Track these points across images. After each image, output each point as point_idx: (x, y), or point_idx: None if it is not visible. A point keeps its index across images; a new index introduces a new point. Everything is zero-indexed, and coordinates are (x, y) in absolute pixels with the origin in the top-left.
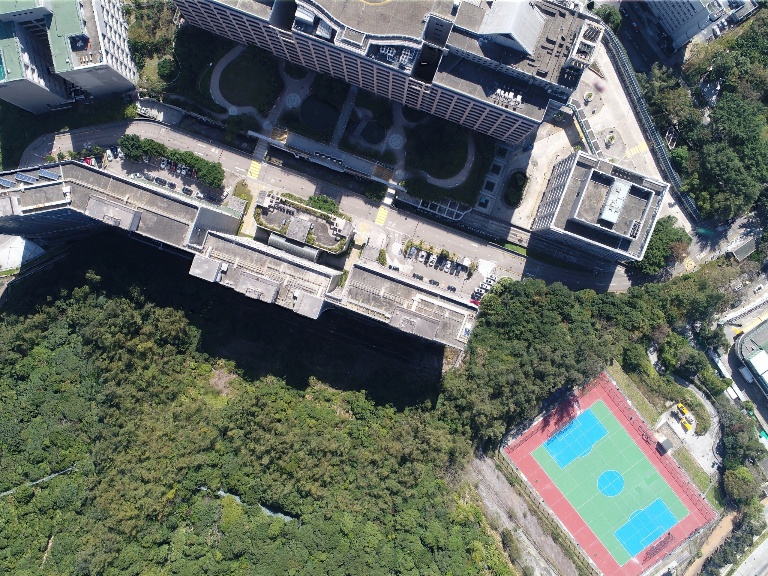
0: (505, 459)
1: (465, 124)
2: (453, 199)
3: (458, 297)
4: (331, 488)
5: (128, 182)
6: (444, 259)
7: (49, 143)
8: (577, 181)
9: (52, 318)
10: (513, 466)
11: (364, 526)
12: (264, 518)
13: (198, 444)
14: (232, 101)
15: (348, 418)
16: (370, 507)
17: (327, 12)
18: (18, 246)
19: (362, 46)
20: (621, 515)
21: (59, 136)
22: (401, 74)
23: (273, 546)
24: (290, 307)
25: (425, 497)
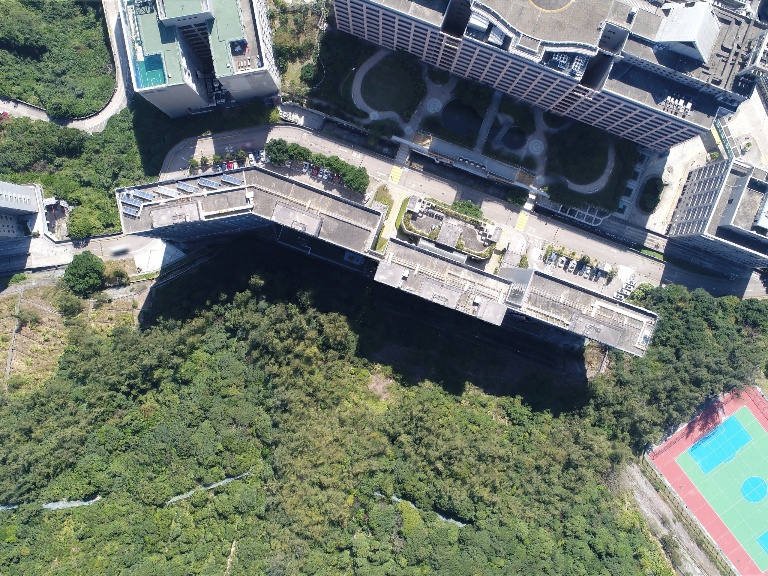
0: (649, 465)
1: (611, 130)
2: (594, 205)
3: None
4: (499, 494)
5: (310, 188)
6: (584, 265)
7: (191, 147)
8: (728, 188)
9: (209, 322)
10: (657, 472)
11: (538, 532)
12: (442, 524)
13: (371, 449)
14: (373, 106)
15: (505, 424)
16: (541, 513)
17: (503, 19)
18: (159, 250)
19: (537, 53)
20: (764, 521)
21: (201, 140)
22: (570, 81)
23: (453, 552)
24: (470, 313)
25: (589, 503)
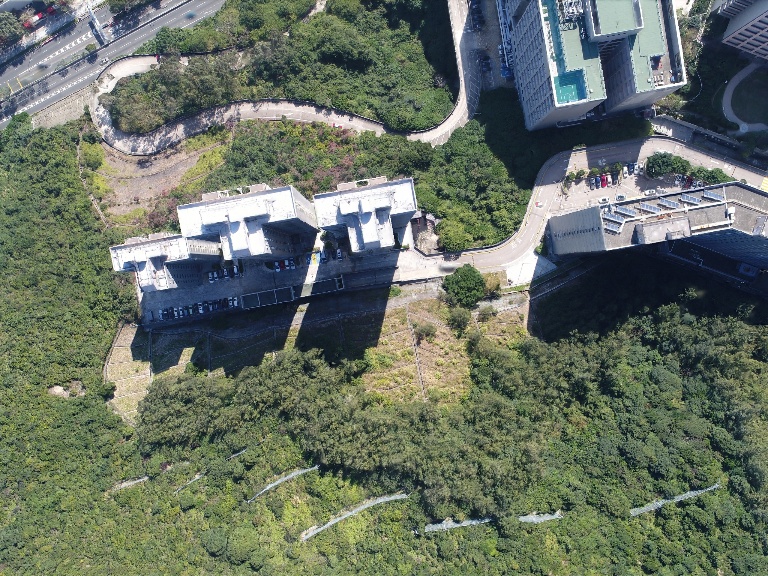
0: None
1: None
2: None
3: None
4: None
5: None
6: None
7: (565, 160)
8: None
9: None
10: None
11: None
12: None
13: None
14: (743, 118)
15: None
16: None
17: None
18: (531, 262)
19: None
20: None
21: (575, 153)
22: None
23: None
24: None
25: None
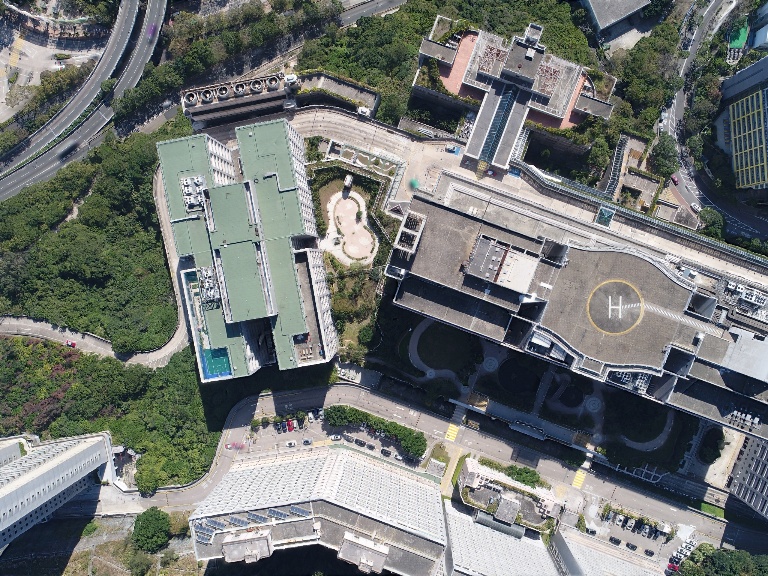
0: None
1: None
2: None
3: (661, 569)
4: None
5: (376, 519)
6: (642, 523)
7: (252, 404)
8: None
9: None
10: None
11: None
12: None
13: None
14: (430, 364)
15: None
16: None
17: (566, 342)
18: None
19: (600, 374)
20: None
21: (262, 398)
22: (633, 392)
23: None
24: None
25: None
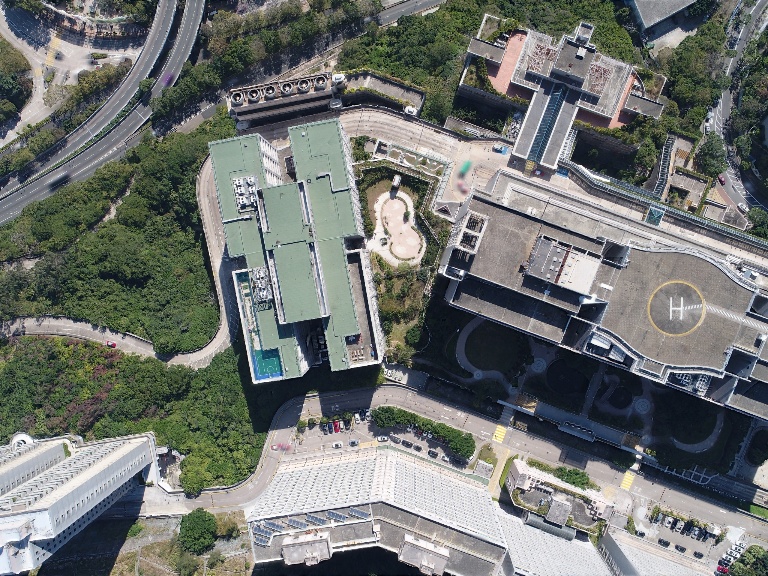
0: None
1: None
2: (703, 467)
3: (712, 572)
4: None
5: (436, 521)
6: (691, 525)
7: (298, 405)
8: None
9: None
10: None
11: None
12: None
13: None
14: (477, 365)
15: None
16: None
17: (626, 343)
18: None
19: None
20: None
21: (308, 399)
22: (692, 393)
23: None
24: None
25: None
